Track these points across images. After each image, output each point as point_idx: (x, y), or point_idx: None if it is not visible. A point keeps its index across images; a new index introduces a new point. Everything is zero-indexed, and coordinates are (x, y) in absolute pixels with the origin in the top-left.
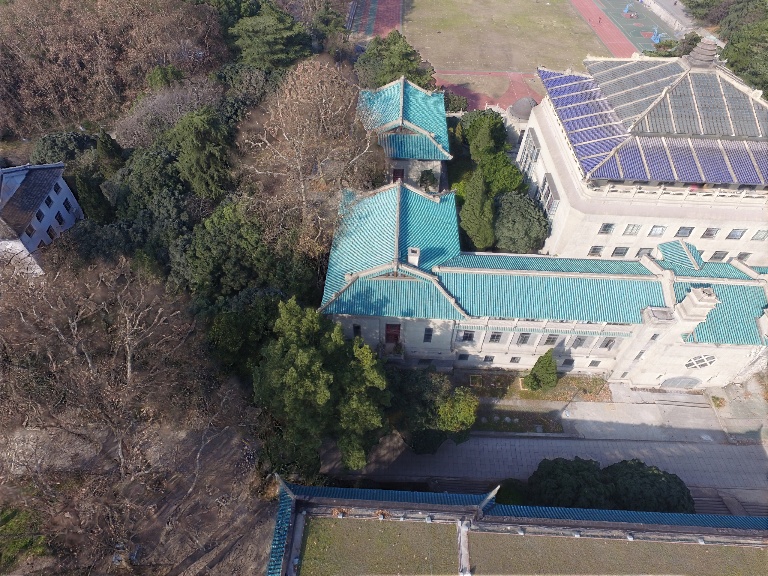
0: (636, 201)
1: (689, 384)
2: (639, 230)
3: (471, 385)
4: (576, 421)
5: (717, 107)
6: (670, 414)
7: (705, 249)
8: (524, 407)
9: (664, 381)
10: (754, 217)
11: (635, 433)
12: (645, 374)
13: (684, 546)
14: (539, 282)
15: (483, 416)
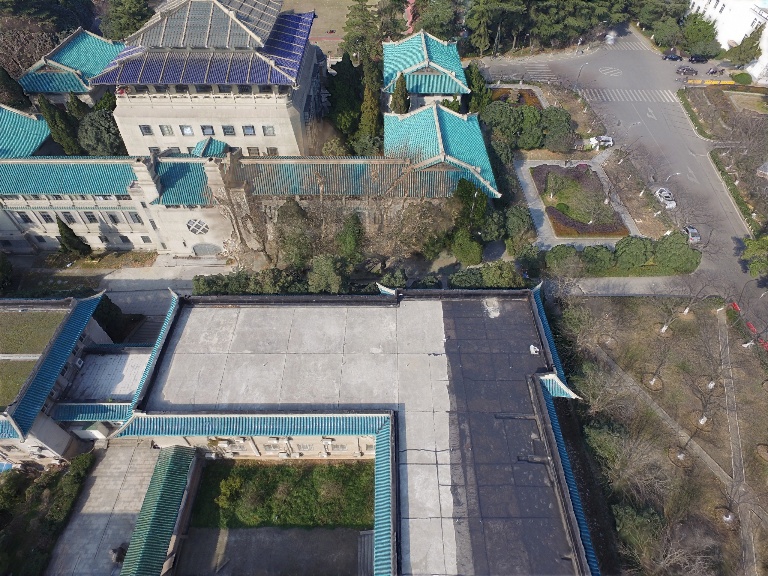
0: (155, 105)
1: (217, 251)
2: (173, 131)
3: (46, 261)
4: (113, 280)
5: (202, 26)
6: (187, 272)
7: (237, 146)
8: (78, 273)
9: (194, 249)
10: (251, 114)
11: (150, 285)
12: (171, 242)
13: (6, 313)
14: (60, 168)
15: (41, 280)
